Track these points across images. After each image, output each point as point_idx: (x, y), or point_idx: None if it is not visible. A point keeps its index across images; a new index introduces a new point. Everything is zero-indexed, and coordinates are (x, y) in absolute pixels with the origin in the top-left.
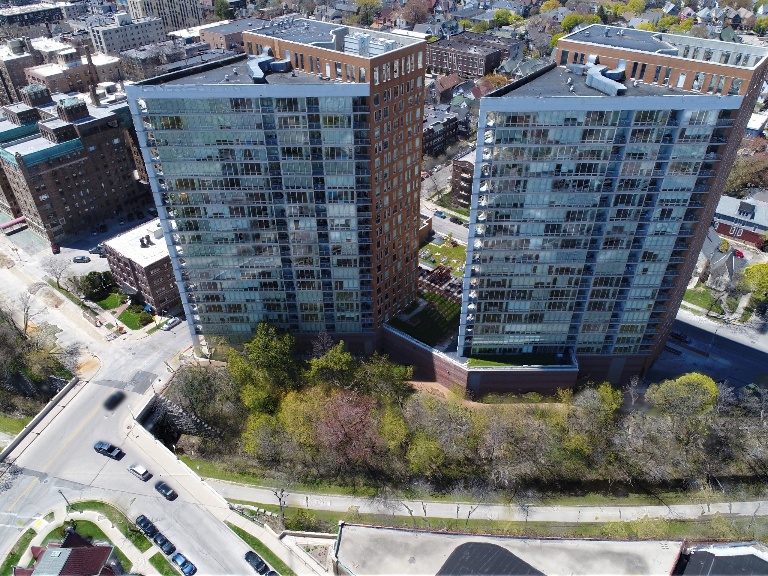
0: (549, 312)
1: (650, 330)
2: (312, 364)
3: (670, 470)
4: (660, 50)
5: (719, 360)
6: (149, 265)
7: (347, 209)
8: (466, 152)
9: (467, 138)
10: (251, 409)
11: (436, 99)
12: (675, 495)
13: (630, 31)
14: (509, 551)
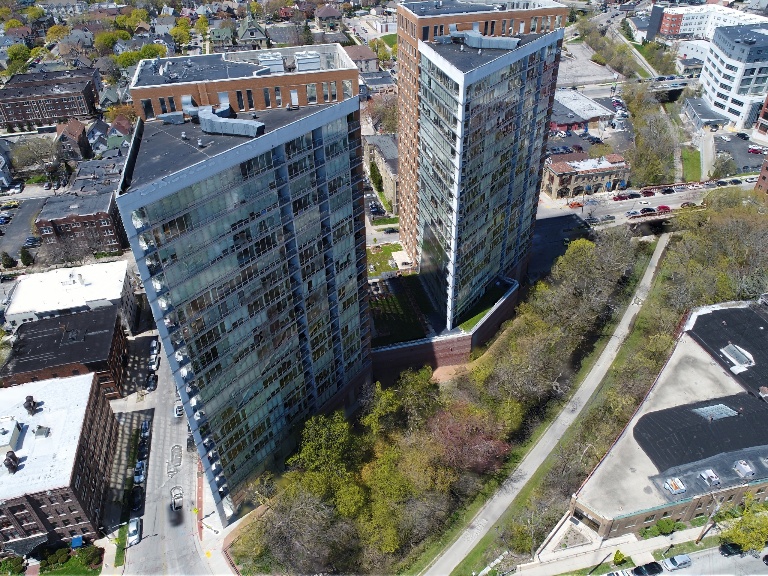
0: (493, 250)
1: (531, 230)
2: (368, 424)
3: (589, 316)
4: (496, 8)
5: (533, 237)
6: (71, 478)
7: (347, 243)
8: None
9: None
10: (351, 514)
11: (74, 152)
12: (607, 327)
13: None
14: (652, 412)
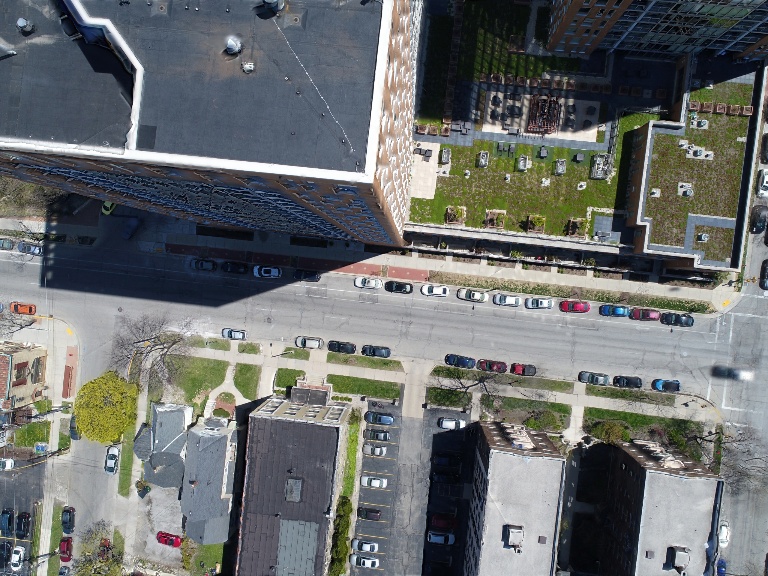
0: None
1: None
2: None
3: None
4: None
5: (153, 245)
6: None
7: None
8: (717, 536)
9: None
10: None
11: None
12: None
13: (223, 119)
14: None
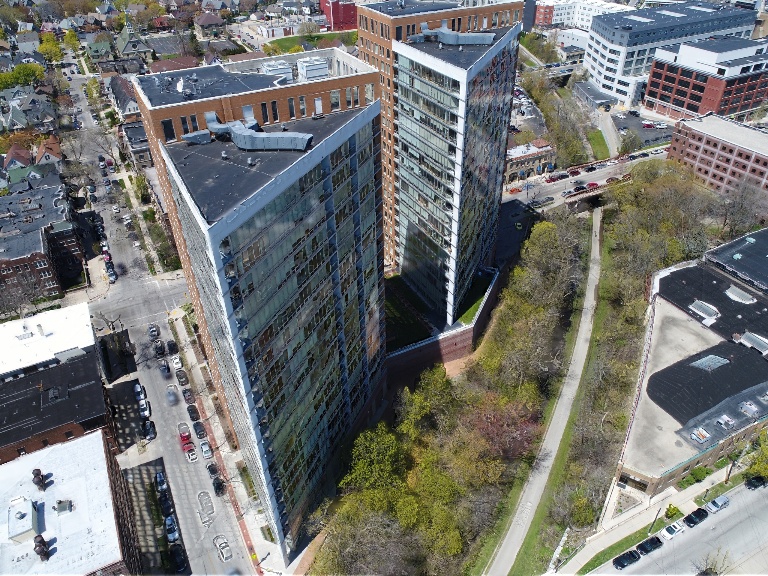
0: None
1: None
2: (406, 431)
3: None
4: (460, 5)
5: None
6: (121, 551)
7: (371, 251)
8: (158, 203)
9: (75, 206)
10: (411, 525)
11: None
12: (576, 302)
13: (396, 2)
14: (656, 372)
